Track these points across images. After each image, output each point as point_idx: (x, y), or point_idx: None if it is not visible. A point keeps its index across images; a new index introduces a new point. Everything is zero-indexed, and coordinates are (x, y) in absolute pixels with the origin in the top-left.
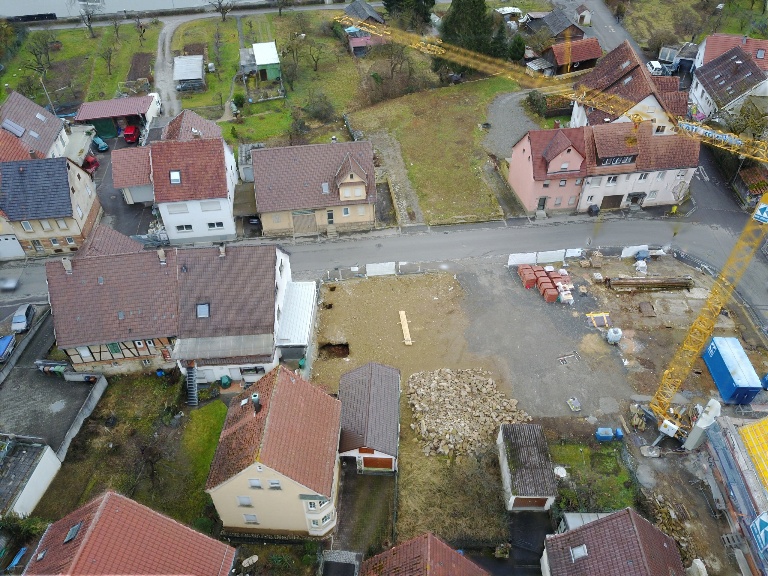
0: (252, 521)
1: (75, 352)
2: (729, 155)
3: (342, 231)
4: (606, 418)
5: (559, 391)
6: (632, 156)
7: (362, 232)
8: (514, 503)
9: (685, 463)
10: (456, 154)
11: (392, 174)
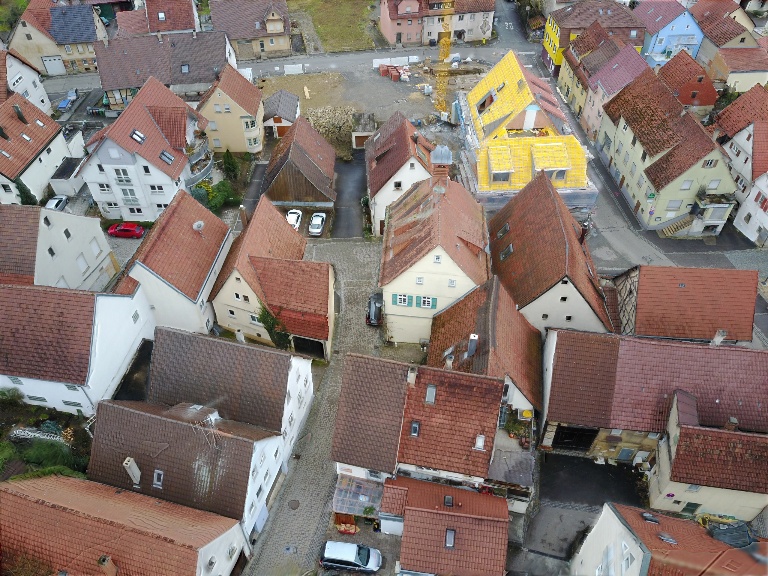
0: (218, 146)
1: (112, 95)
2: (524, 11)
3: (271, 57)
4: (415, 120)
5: (392, 112)
6: (451, 3)
7: (283, 57)
8: (356, 143)
9: (453, 134)
10: (349, 21)
11: (305, 31)
